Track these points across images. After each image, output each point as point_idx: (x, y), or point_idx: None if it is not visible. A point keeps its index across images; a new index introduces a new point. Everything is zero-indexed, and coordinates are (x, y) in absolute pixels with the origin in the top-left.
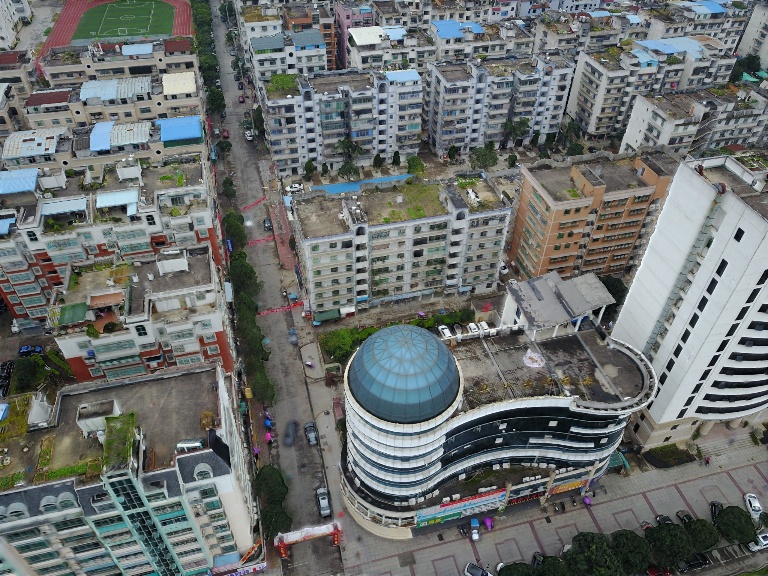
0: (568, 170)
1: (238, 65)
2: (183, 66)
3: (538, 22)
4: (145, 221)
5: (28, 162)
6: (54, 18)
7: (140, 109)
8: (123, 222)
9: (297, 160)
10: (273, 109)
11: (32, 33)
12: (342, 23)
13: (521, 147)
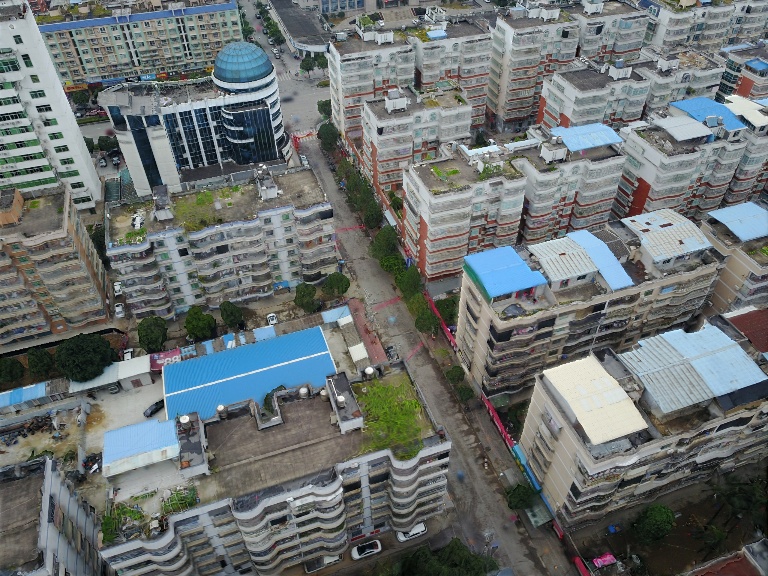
0: None
1: None
2: None
3: None
4: None
5: None
6: None
7: None
8: None
9: None
10: None
11: None
12: None
13: None
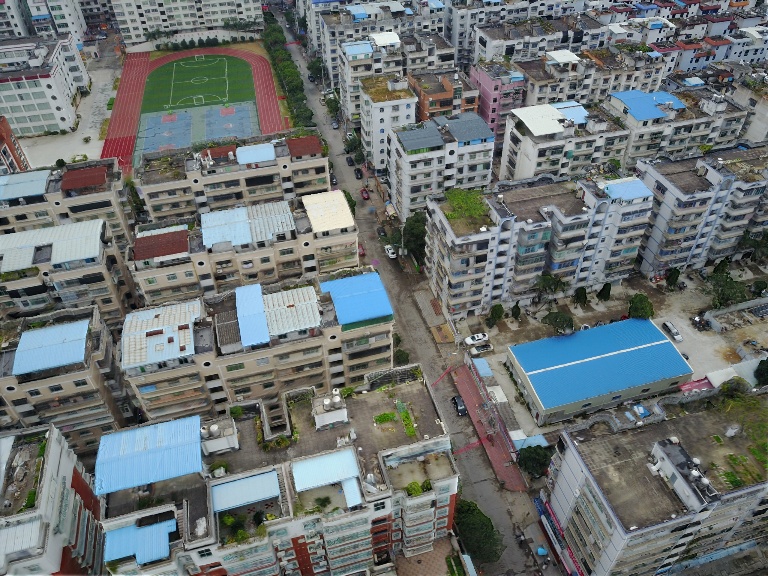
0: None
1: (354, 148)
2: (312, 172)
3: (739, 86)
4: (371, 508)
5: (156, 368)
6: (115, 85)
7: (279, 251)
8: (336, 509)
9: (479, 302)
10: (460, 246)
11: (93, 106)
12: (484, 94)
13: (749, 259)
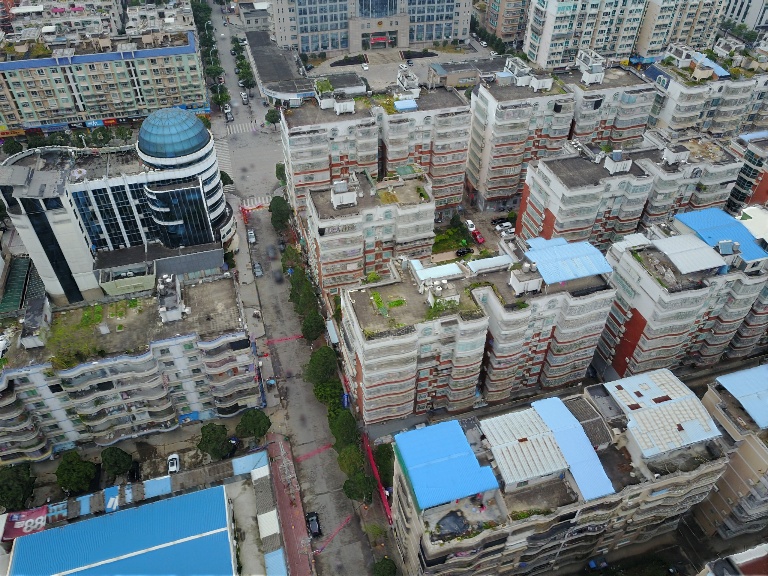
0: None
1: None
2: None
3: None
4: None
5: None
6: None
7: None
8: None
9: None
10: None
11: None
12: None
13: None
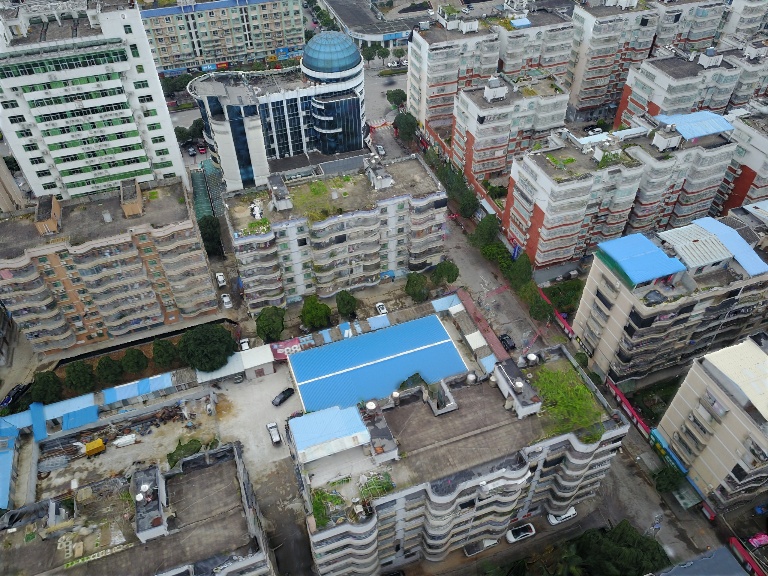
0: (138, 225)
1: None
2: None
3: None
4: None
5: None
6: None
7: None
8: None
9: None
10: None
11: None
12: None
13: None
